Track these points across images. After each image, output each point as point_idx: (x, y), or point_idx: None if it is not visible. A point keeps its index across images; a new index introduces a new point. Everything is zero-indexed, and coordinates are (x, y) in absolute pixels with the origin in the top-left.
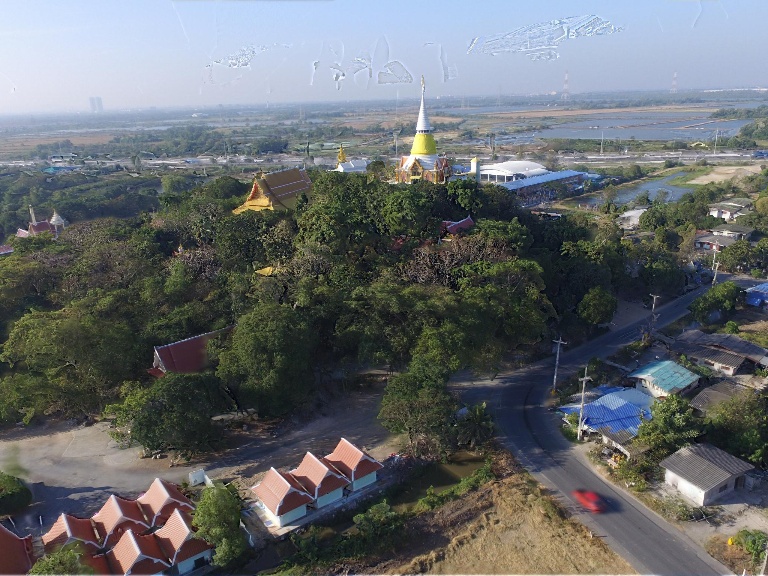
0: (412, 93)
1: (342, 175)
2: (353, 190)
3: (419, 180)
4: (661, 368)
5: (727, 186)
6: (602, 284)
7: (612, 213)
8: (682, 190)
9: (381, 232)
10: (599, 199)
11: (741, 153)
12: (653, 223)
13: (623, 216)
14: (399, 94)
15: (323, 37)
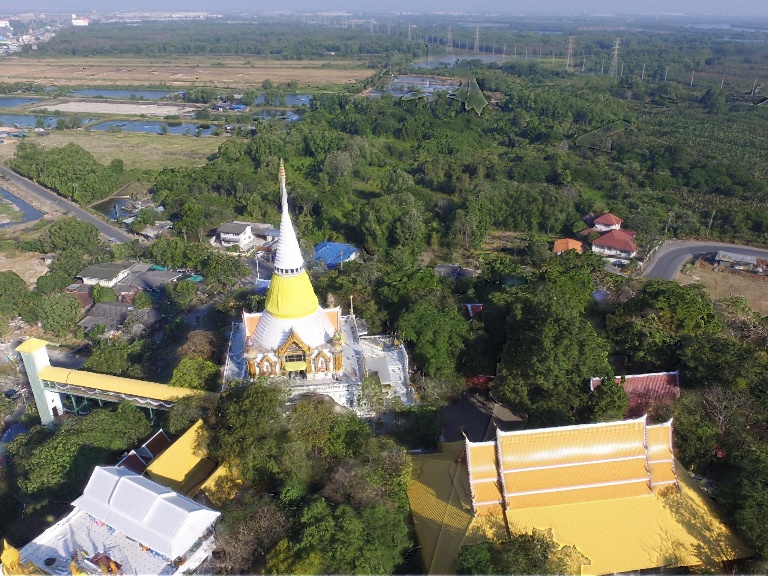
0: None
1: None
2: None
3: None
4: None
5: None
6: None
7: None
8: None
9: (611, 306)
10: None
11: None
12: None
13: None
14: None
15: None
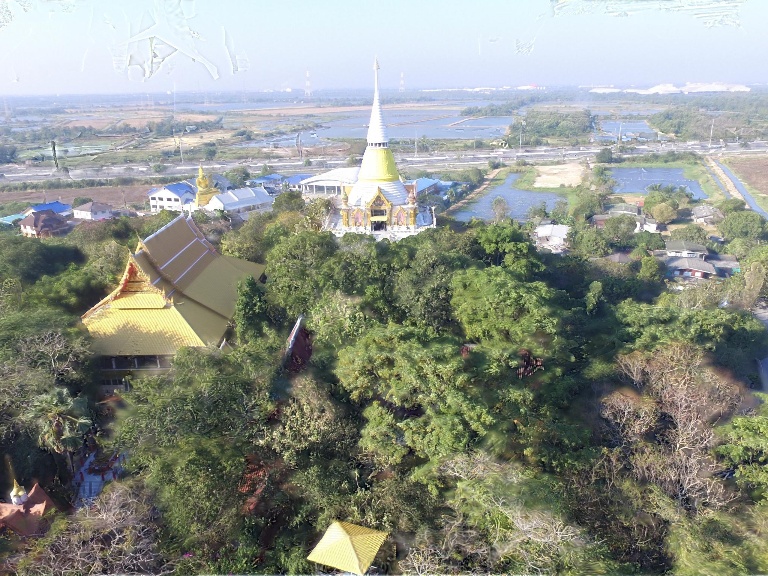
0: (194, 86)
1: (327, 238)
2: (359, 266)
3: (384, 222)
4: None
5: None
6: (743, 374)
7: None
8: (541, 195)
9: None
10: (475, 212)
11: (552, 152)
12: (602, 246)
13: (541, 236)
14: (177, 87)
15: (92, 2)
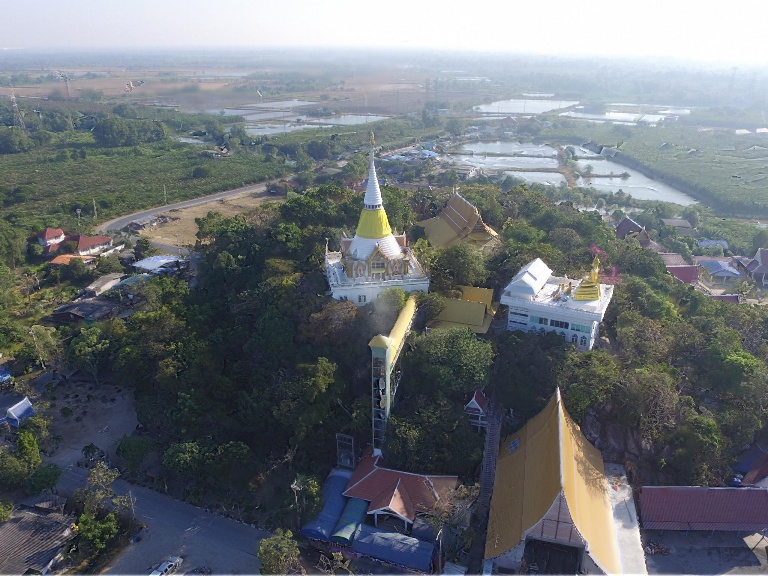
0: None
1: None
2: None
3: None
4: (134, 279)
5: None
6: None
7: None
8: None
9: None
10: None
11: None
12: None
13: None
14: None
15: None
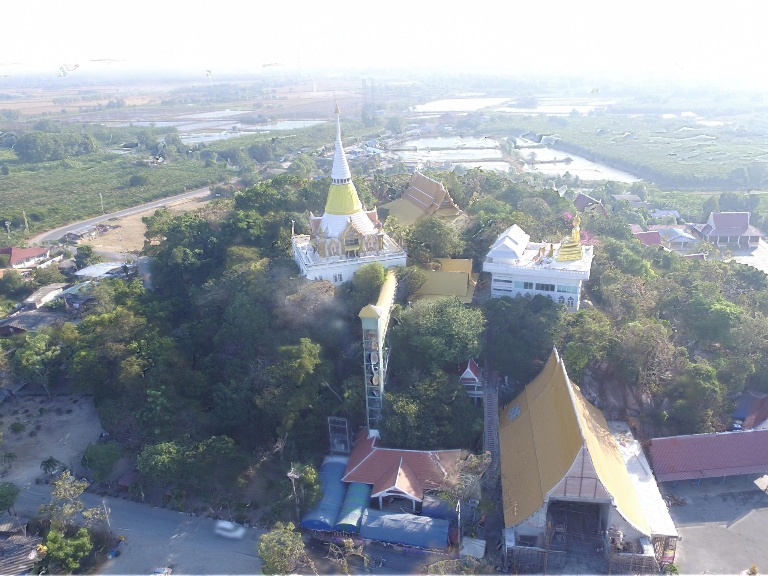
0: None
1: None
2: None
3: None
4: None
5: None
6: None
7: None
8: None
9: None
10: None
11: None
12: None
13: None
14: None
15: None
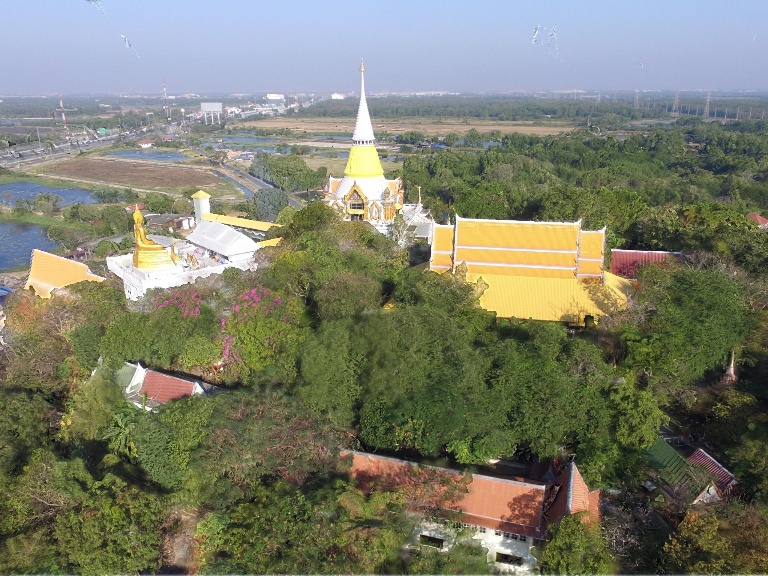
0: None
1: None
2: None
3: None
4: None
5: (52, 208)
6: None
7: (126, 251)
8: None
9: None
10: None
11: None
12: None
13: None
14: None
15: None
